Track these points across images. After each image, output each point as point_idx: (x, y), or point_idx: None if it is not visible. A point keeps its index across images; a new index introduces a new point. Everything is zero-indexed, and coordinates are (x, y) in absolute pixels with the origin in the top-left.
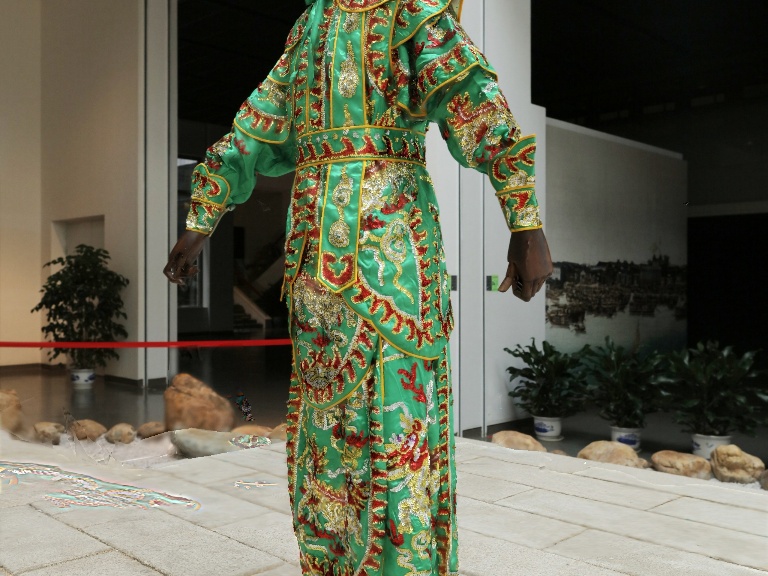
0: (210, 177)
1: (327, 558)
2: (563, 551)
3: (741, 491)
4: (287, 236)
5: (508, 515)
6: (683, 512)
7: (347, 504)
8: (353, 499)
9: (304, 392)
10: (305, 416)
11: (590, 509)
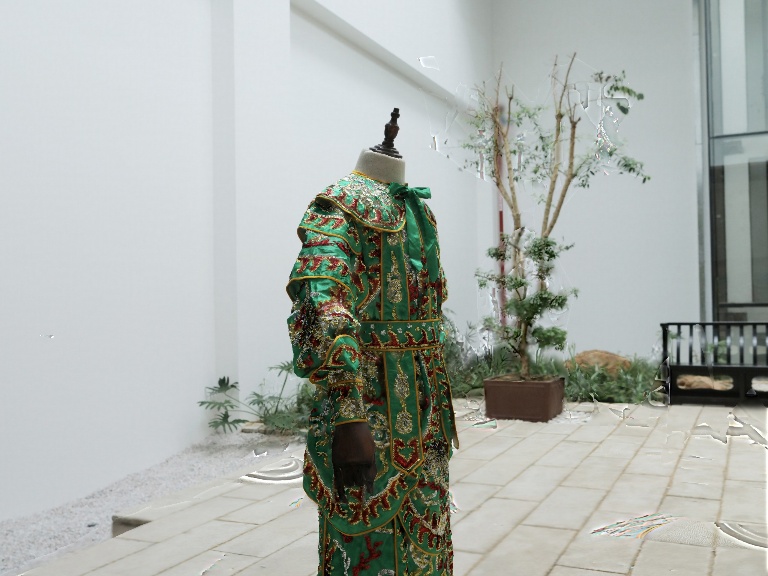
0: None
1: None
2: None
3: None
4: (431, 411)
5: None
6: None
7: None
8: None
9: None
10: None
11: None
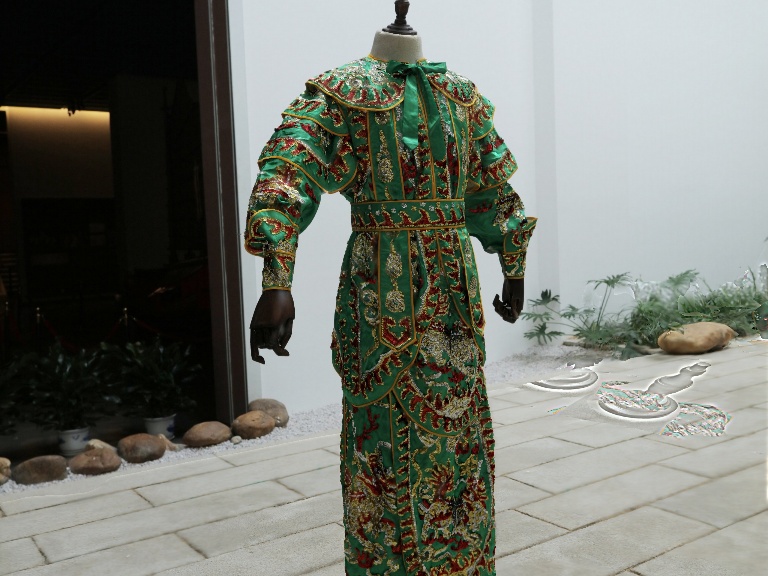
0: (294, 227)
1: (449, 560)
2: (221, 549)
3: (148, 470)
4: (426, 291)
5: (102, 559)
6: (175, 496)
7: (473, 502)
8: (477, 496)
9: (441, 426)
10: (413, 452)
11: (128, 524)
